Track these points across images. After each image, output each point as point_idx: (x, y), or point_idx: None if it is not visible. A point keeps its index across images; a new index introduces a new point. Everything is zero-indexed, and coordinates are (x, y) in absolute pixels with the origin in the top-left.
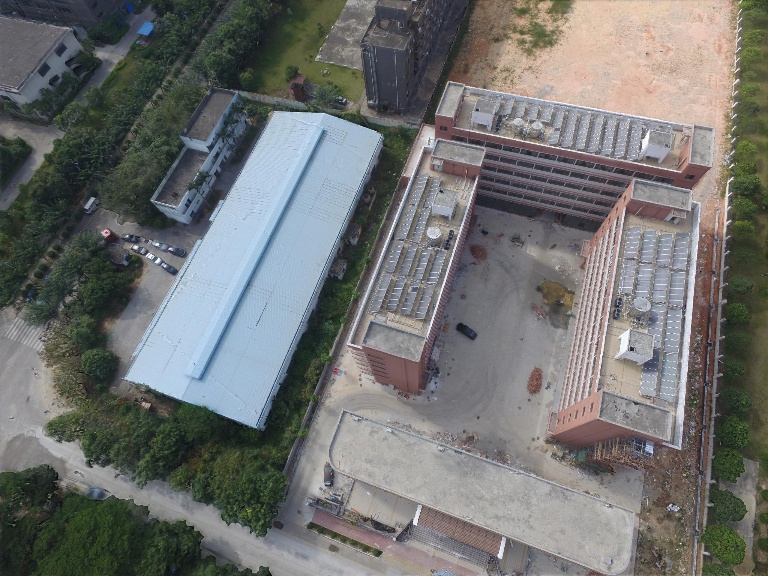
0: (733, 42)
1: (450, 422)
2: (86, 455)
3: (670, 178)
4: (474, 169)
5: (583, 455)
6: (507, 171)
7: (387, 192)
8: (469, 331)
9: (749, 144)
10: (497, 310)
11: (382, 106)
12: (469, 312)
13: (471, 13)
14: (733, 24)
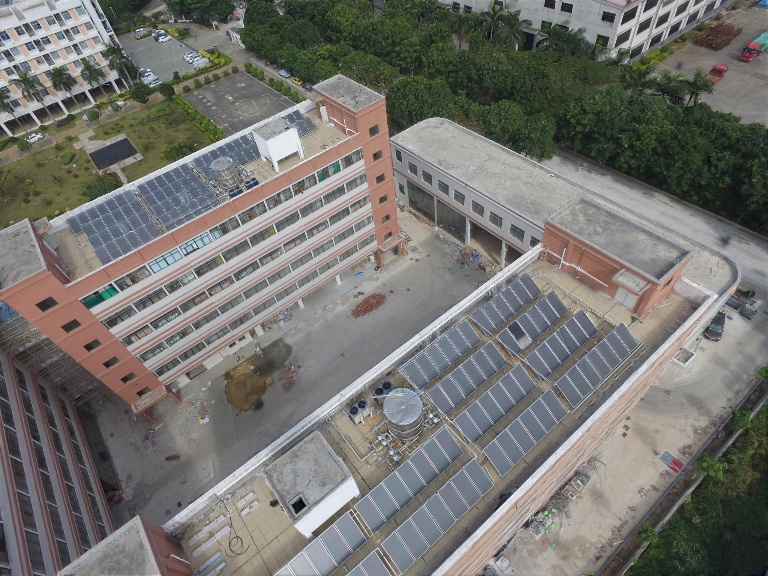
0: None
1: None
2: None
3: None
4: None
5: None
6: None
7: None
8: None
9: None
10: None
11: None
12: None
13: None
14: None
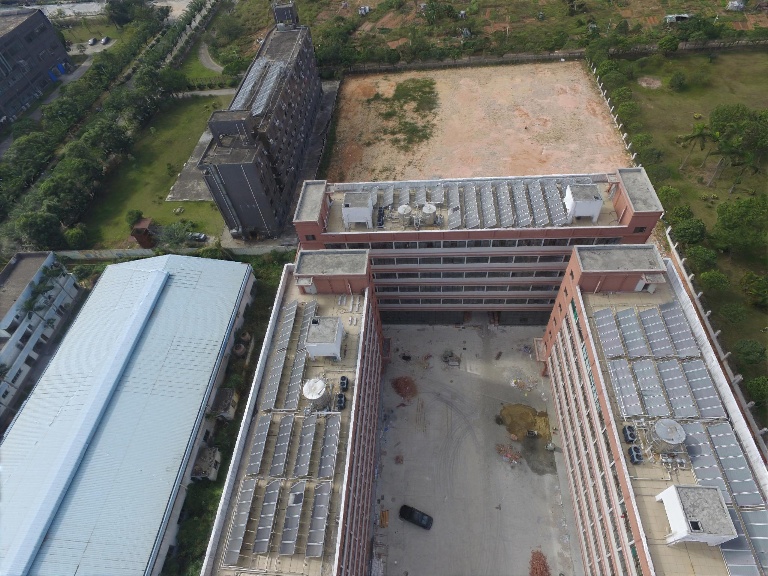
0: (604, 104)
1: None
2: None
3: (615, 237)
4: (358, 280)
5: None
6: (410, 274)
7: None
8: (419, 516)
9: (670, 189)
10: (451, 468)
11: (249, 233)
12: (412, 483)
13: (336, 125)
14: (596, 90)
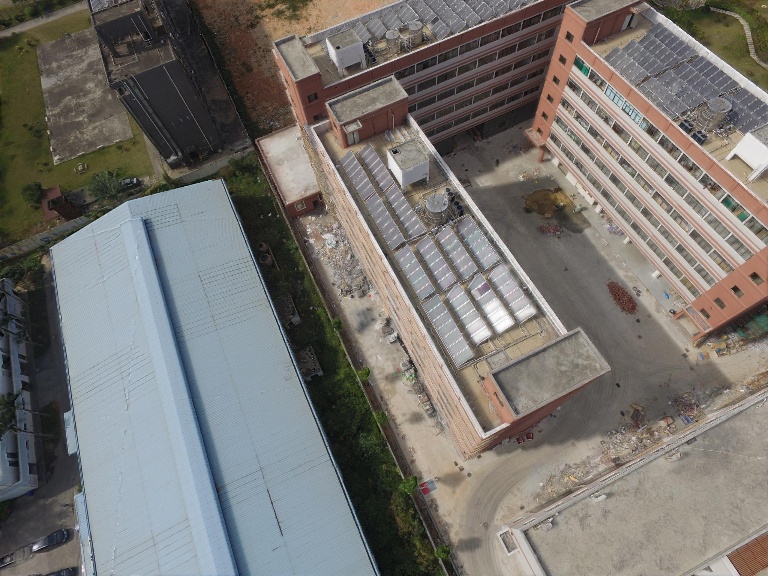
0: None
1: (599, 418)
2: None
3: None
4: (400, 107)
5: (764, 322)
6: None
7: (280, 238)
8: None
9: None
10: None
11: (188, 156)
12: None
13: (201, 18)
14: None
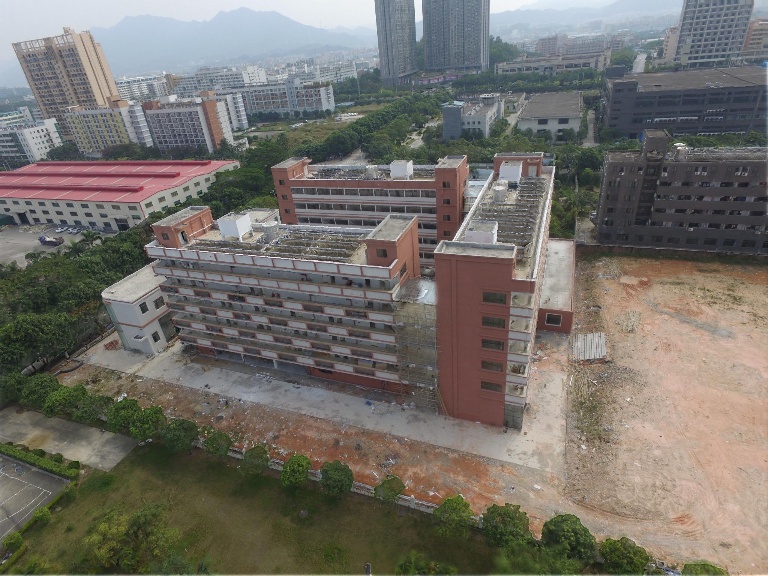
0: None
1: None
2: None
3: None
4: None
5: None
6: None
7: None
8: None
9: None
10: None
11: None
12: None
13: None
14: None
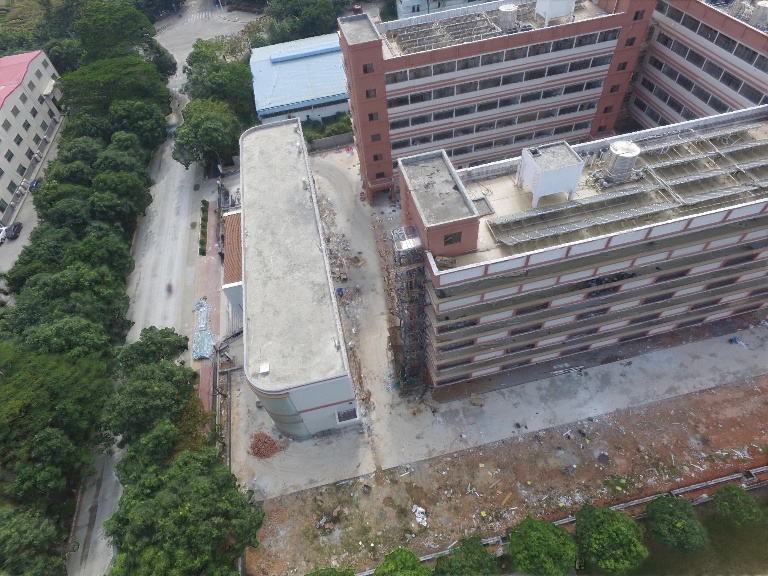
0: None
1: (361, 239)
2: (187, 58)
3: None
4: None
5: None
6: (688, 82)
7: None
8: None
9: None
10: None
11: None
12: None
13: None
14: None
